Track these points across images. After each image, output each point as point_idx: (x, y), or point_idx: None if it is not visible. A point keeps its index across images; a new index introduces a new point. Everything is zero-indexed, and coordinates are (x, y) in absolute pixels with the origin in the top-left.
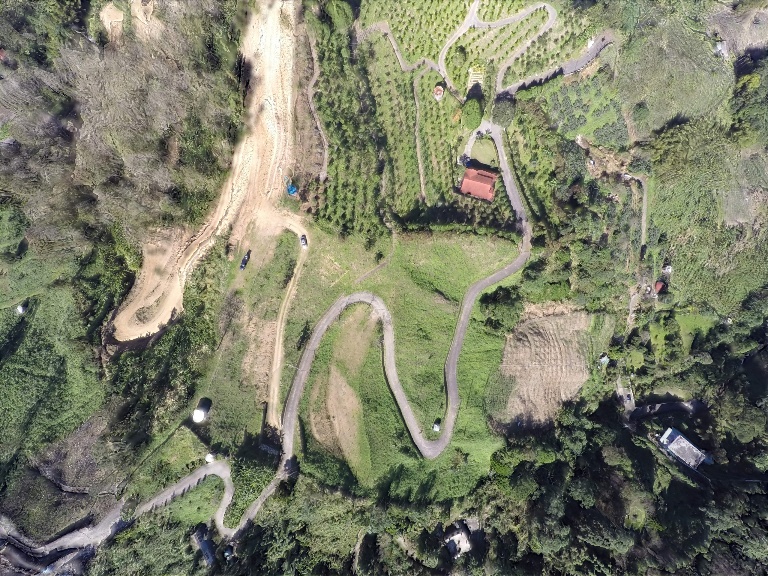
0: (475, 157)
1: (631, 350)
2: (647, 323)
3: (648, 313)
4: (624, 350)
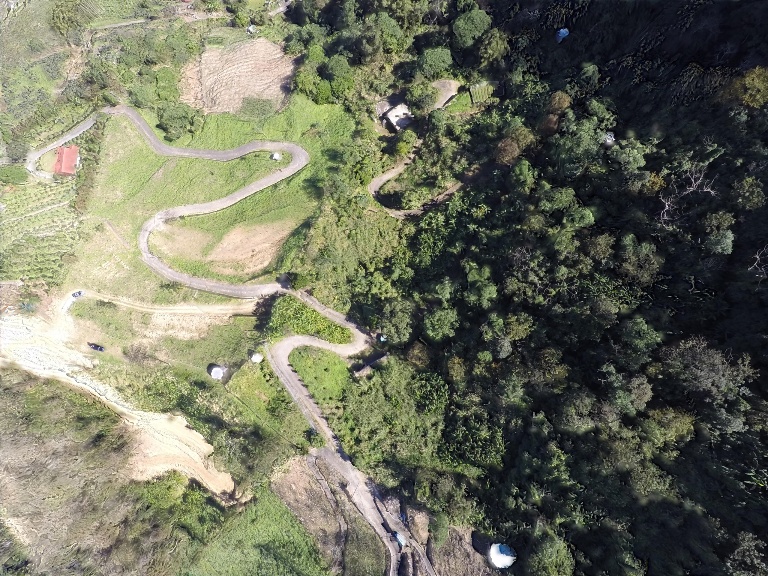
0: (54, 168)
1: (243, 8)
2: (226, 2)
3: (210, 2)
4: (238, 13)
